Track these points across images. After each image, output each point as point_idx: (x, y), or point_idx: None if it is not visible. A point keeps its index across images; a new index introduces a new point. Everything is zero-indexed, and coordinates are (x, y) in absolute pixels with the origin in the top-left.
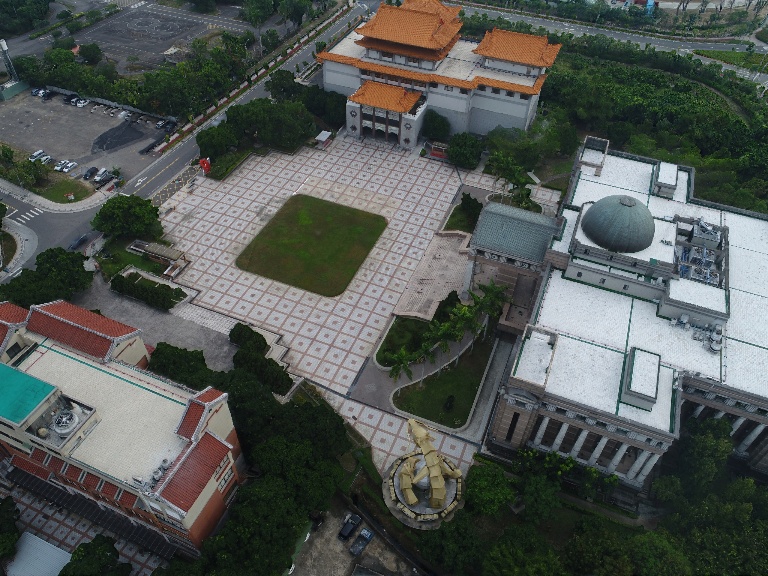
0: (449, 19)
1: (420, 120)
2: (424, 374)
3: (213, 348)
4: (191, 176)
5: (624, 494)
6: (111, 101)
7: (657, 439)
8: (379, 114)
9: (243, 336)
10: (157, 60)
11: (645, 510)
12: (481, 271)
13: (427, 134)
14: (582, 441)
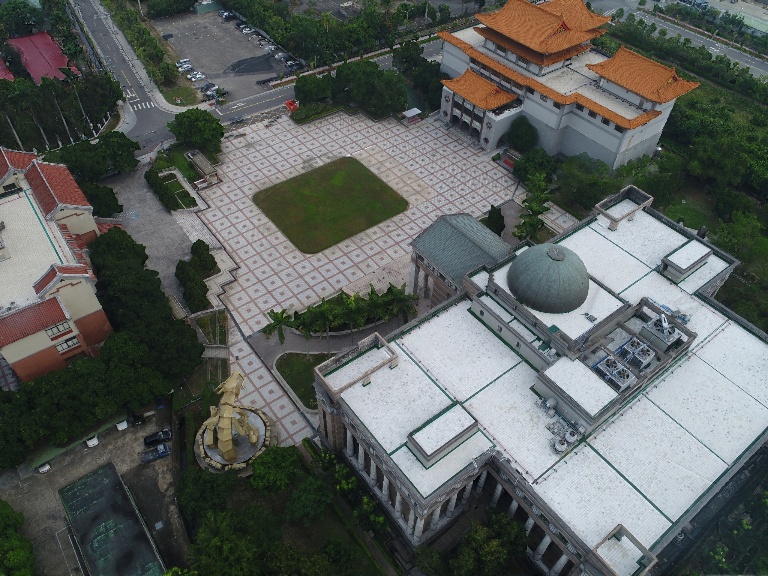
0: (586, 27)
1: (506, 123)
2: (321, 350)
3: (178, 254)
4: (279, 113)
5: (404, 547)
6: (267, 34)
7: (413, 498)
8: (467, 105)
9: (198, 252)
10: (334, 10)
11: (417, 574)
12: None
13: (508, 140)
14: (372, 469)
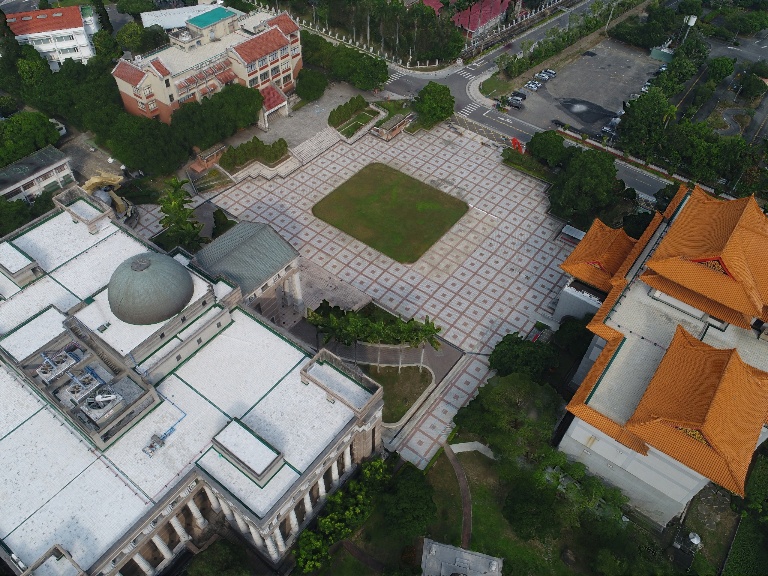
0: None
1: (579, 306)
2: None
3: None
4: None
5: None
6: None
7: None
8: None
9: None
10: None
11: None
12: (285, 304)
13: None
14: None
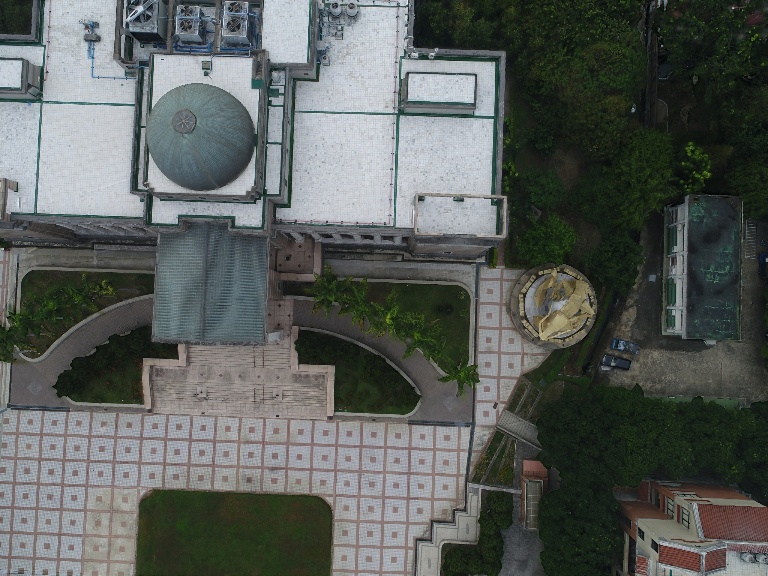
0: None
1: None
2: None
3: None
4: None
5: None
6: None
7: None
8: None
9: None
10: None
11: None
12: None
13: None
14: None
